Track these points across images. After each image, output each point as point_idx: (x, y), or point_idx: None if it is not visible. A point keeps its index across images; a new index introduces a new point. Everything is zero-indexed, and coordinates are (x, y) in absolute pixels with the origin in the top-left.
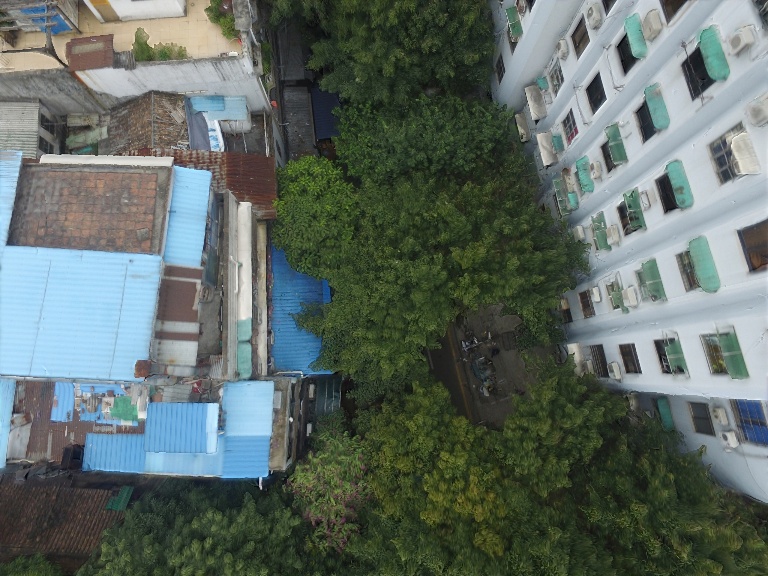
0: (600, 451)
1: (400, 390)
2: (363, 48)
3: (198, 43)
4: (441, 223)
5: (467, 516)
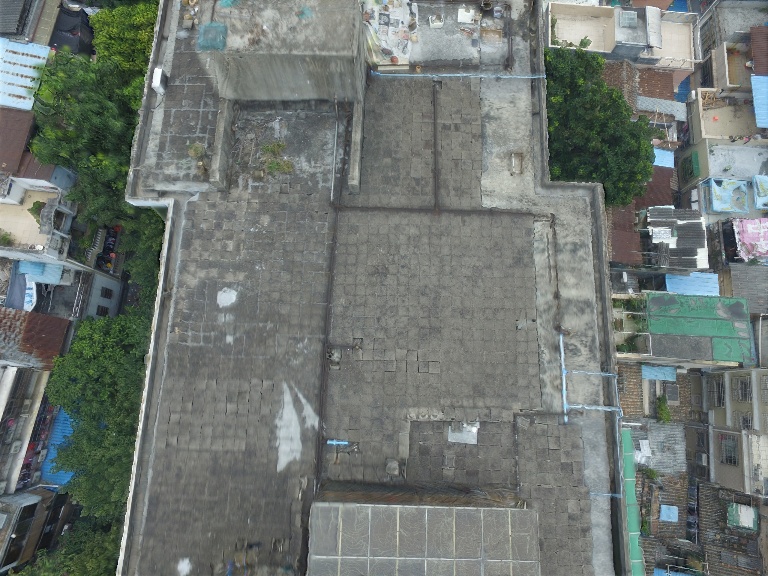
0: None
1: None
2: (145, 254)
3: (24, 228)
4: None
5: None
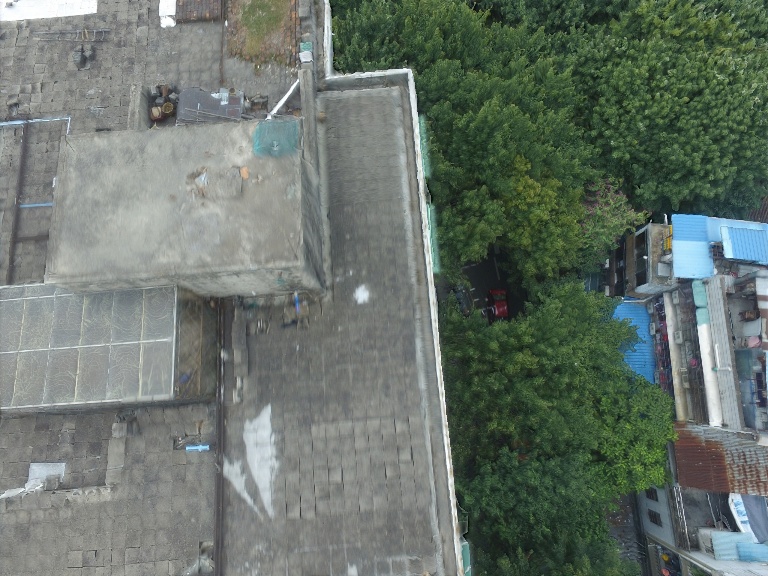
0: (433, 212)
1: (548, 279)
2: None
3: None
4: None
5: None
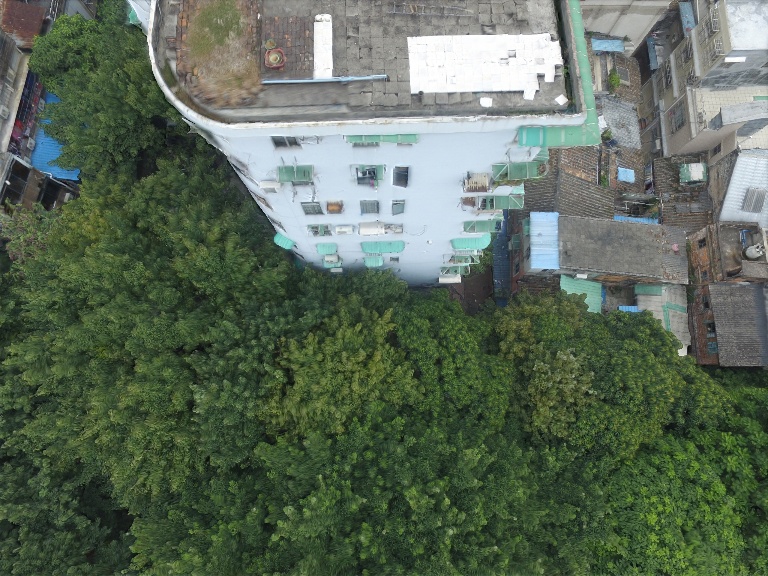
0: None
1: None
2: None
3: None
4: (139, 57)
5: (90, 239)
